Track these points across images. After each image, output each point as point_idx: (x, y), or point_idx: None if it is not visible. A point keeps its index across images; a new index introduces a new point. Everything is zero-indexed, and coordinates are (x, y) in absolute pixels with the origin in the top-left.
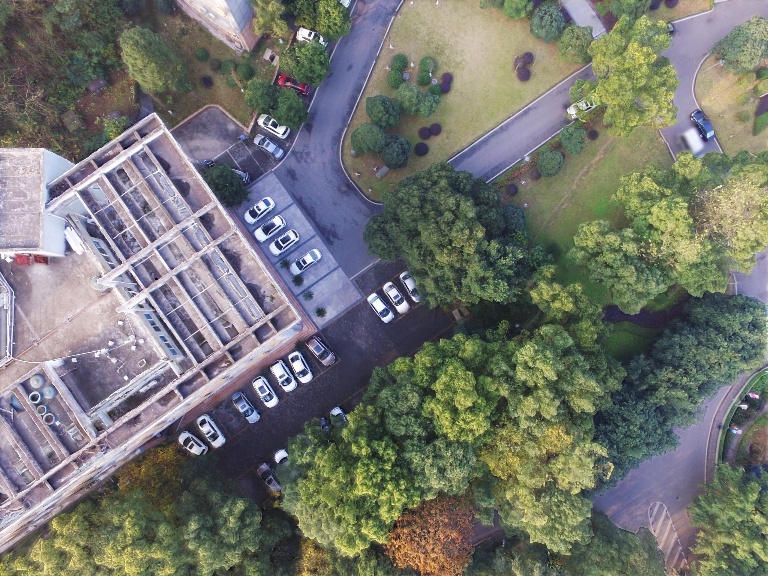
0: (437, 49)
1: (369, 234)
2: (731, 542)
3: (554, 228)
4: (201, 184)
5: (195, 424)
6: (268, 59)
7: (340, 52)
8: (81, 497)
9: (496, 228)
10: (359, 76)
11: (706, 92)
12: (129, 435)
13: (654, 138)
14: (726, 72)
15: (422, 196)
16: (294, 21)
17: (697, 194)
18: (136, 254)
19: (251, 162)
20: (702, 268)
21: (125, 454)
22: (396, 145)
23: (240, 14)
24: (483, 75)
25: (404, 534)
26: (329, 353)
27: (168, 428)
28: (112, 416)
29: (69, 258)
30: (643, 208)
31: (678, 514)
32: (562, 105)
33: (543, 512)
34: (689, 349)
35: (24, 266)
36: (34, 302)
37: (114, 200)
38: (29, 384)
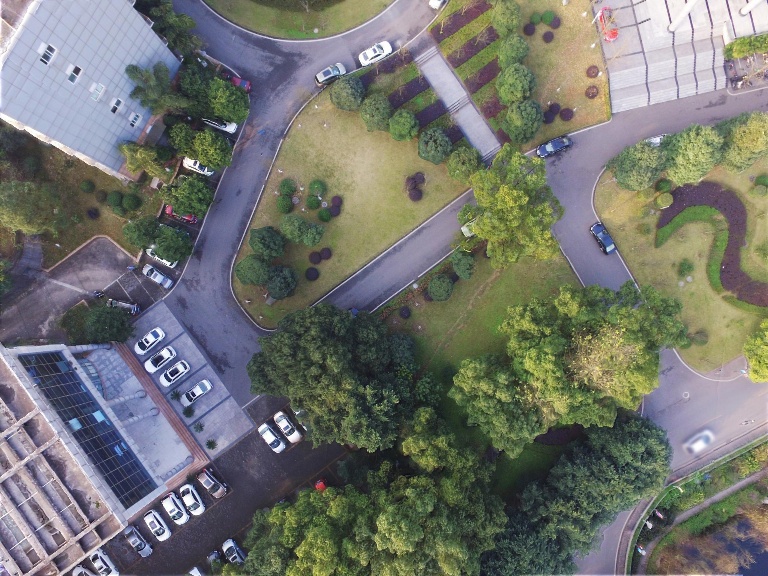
0: (326, 171)
1: (251, 373)
2: None
3: (450, 350)
4: None
5: None
6: (155, 187)
7: (229, 177)
8: None
9: (378, 365)
10: (248, 201)
11: (605, 205)
12: None
13: None
14: (622, 188)
15: (295, 343)
16: (176, 154)
17: (574, 337)
18: None
19: (141, 291)
20: None
21: None
22: (278, 280)
23: (112, 158)
24: (374, 196)
25: None
26: (220, 486)
27: None
28: None
29: None
30: (521, 350)
31: None
32: (456, 223)
33: None
34: (581, 480)
35: None
36: None
37: None
38: None
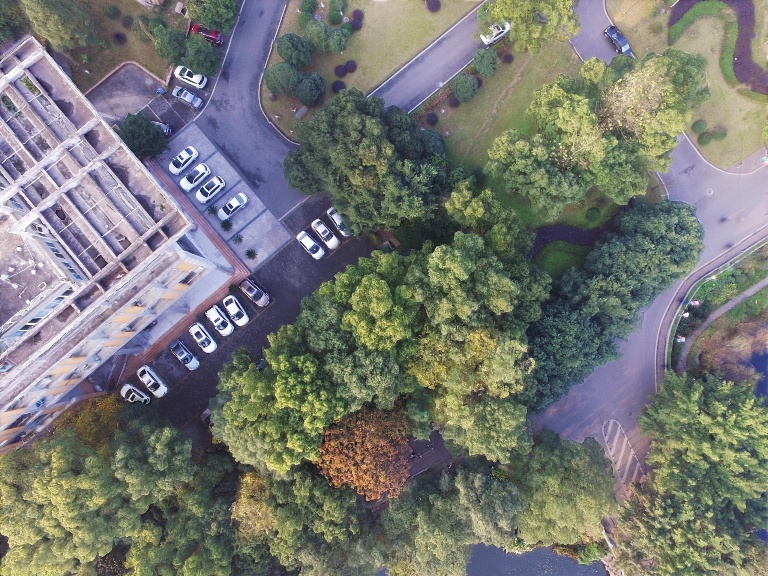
0: None
1: (288, 169)
2: (680, 445)
3: (478, 153)
4: (84, 102)
5: (136, 377)
6: (180, 13)
7: None
8: (18, 448)
9: (412, 151)
10: (271, 21)
11: (617, 7)
12: (30, 353)
13: None
14: None
15: (332, 122)
16: None
17: (603, 94)
18: (23, 175)
19: (172, 115)
20: (617, 169)
21: (55, 398)
22: (308, 80)
23: None
24: (394, 9)
25: (331, 447)
26: (262, 293)
27: (109, 383)
28: None
29: None
30: (552, 114)
31: (632, 430)
32: (475, 32)
33: (477, 422)
34: (618, 255)
35: None
36: None
37: None
38: None
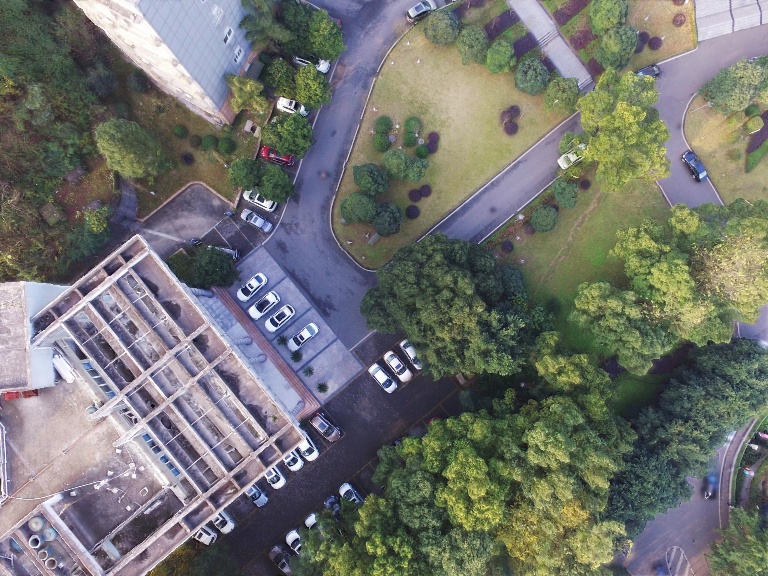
0: (422, 108)
1: (366, 309)
2: None
3: (553, 282)
4: (192, 305)
5: None
6: (249, 131)
7: (323, 118)
8: None
9: (495, 294)
10: (344, 141)
11: (696, 132)
12: (136, 573)
13: (647, 182)
14: (715, 113)
15: (418, 271)
16: (274, 93)
17: (696, 251)
18: (129, 385)
19: (240, 238)
20: (706, 323)
21: None
22: (387, 215)
23: (218, 95)
24: (470, 132)
25: None
26: (334, 429)
27: None
28: (117, 544)
29: (59, 387)
30: (643, 267)
31: (695, 557)
32: (552, 156)
33: None
34: (697, 400)
35: (13, 399)
36: (26, 436)
37: (102, 328)
38: (27, 528)
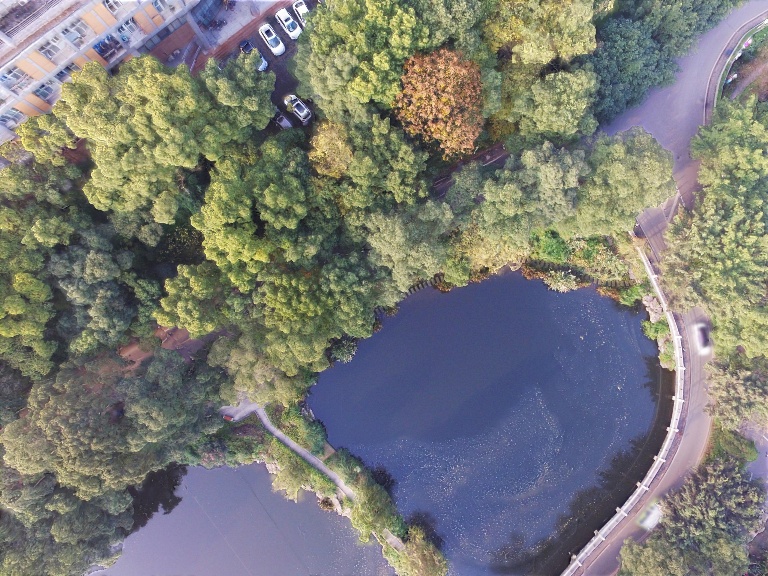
0: None
1: None
2: (732, 157)
3: None
4: None
5: None
6: None
7: None
8: None
9: None
10: None
11: None
12: None
13: None
14: None
15: None
16: None
17: None
18: None
19: None
20: None
21: (139, 40)
22: None
23: None
24: None
25: (415, 73)
26: None
27: None
28: None
29: None
30: None
31: (680, 173)
32: None
33: None
34: None
35: None
36: None
37: None
38: None
